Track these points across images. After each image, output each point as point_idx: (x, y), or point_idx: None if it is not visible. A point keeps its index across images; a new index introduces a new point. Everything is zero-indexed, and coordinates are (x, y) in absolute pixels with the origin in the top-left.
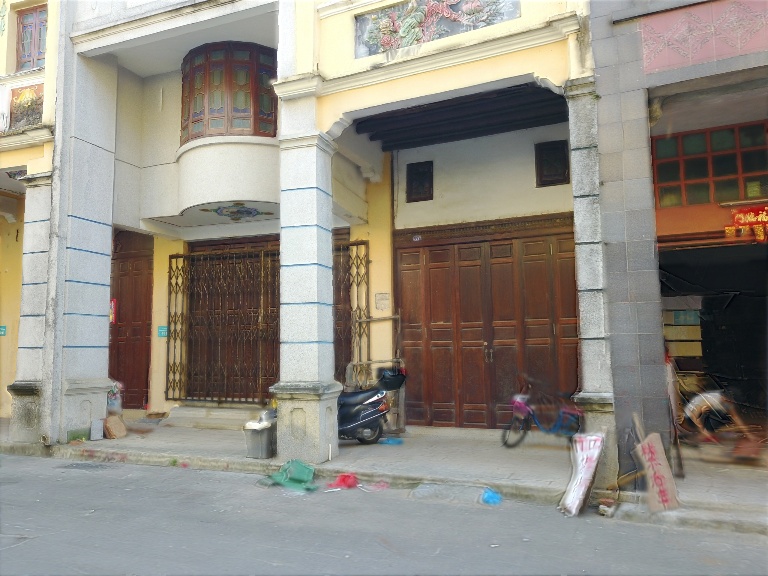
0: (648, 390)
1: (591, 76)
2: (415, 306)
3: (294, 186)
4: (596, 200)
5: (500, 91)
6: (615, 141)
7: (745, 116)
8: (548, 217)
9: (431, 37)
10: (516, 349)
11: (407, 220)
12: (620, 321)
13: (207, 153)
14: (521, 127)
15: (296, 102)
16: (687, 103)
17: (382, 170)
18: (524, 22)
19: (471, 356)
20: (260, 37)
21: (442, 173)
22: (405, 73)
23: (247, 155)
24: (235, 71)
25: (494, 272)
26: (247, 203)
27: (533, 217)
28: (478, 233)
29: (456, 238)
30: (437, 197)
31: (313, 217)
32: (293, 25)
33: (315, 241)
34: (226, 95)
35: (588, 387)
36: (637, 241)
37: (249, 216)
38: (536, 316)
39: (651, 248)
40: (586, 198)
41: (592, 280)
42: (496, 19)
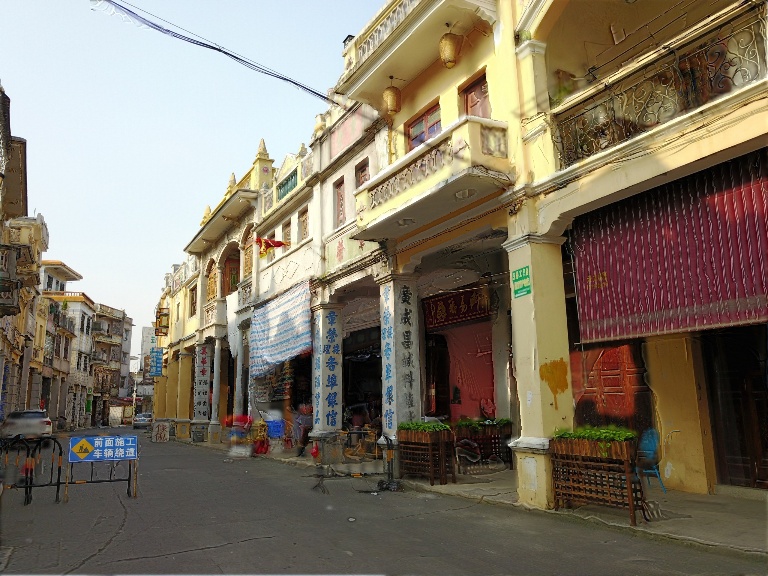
0: None
1: None
2: None
3: None
4: None
5: None
6: None
7: None
8: None
9: None
10: None
11: None
12: None
13: None
14: None
15: None
16: None
17: None
18: None
19: None
20: None
21: None
22: None
23: None
24: None
25: None
26: None
27: None
28: None
29: None
30: None
31: None
32: None
33: None
34: None
35: None
36: None
37: None
38: None
39: None
40: None
41: (38, 403)
42: None
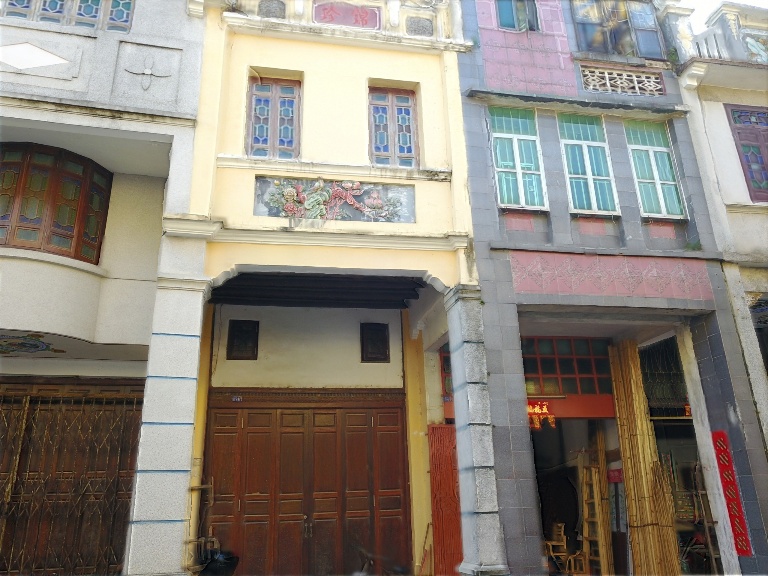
0: (533, 560)
1: (478, 285)
2: (228, 474)
3: (171, 331)
4: (486, 387)
5: (372, 276)
6: (496, 341)
7: (526, 331)
8: (372, 391)
9: (334, 217)
10: (337, 522)
11: (226, 378)
12: (509, 496)
13: (5, 267)
14: (353, 306)
15: (182, 241)
16: (526, 319)
17: (204, 321)
18: (419, 228)
19: (289, 531)
20: (103, 156)
21: (268, 335)
22: (309, 242)
23: (63, 279)
24: (62, 182)
25: (317, 441)
26: (49, 336)
27: (358, 390)
28: (303, 400)
29: (280, 403)
30: (262, 358)
31: (193, 369)
32: (189, 164)
33: (194, 397)
34: (46, 205)
35: (487, 560)
36: (517, 426)
37: (27, 351)
38: (357, 487)
39: (528, 433)
40: (477, 385)
41: (486, 458)
42: (393, 218)
